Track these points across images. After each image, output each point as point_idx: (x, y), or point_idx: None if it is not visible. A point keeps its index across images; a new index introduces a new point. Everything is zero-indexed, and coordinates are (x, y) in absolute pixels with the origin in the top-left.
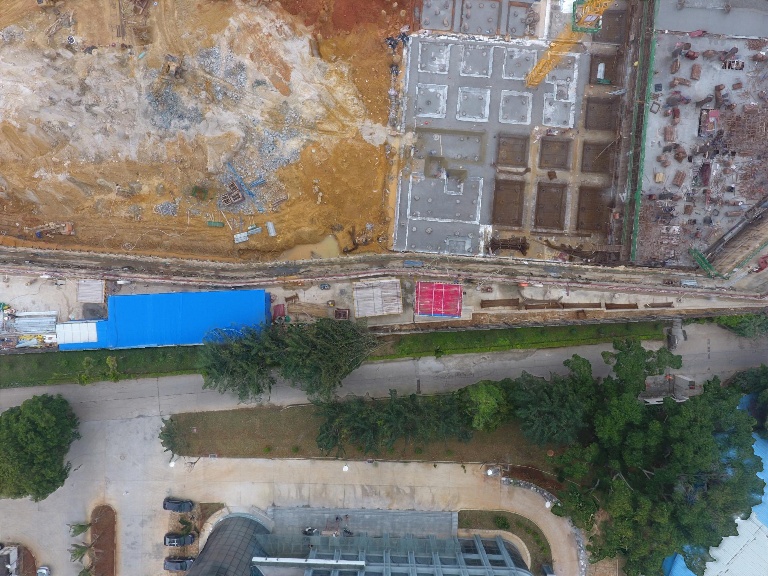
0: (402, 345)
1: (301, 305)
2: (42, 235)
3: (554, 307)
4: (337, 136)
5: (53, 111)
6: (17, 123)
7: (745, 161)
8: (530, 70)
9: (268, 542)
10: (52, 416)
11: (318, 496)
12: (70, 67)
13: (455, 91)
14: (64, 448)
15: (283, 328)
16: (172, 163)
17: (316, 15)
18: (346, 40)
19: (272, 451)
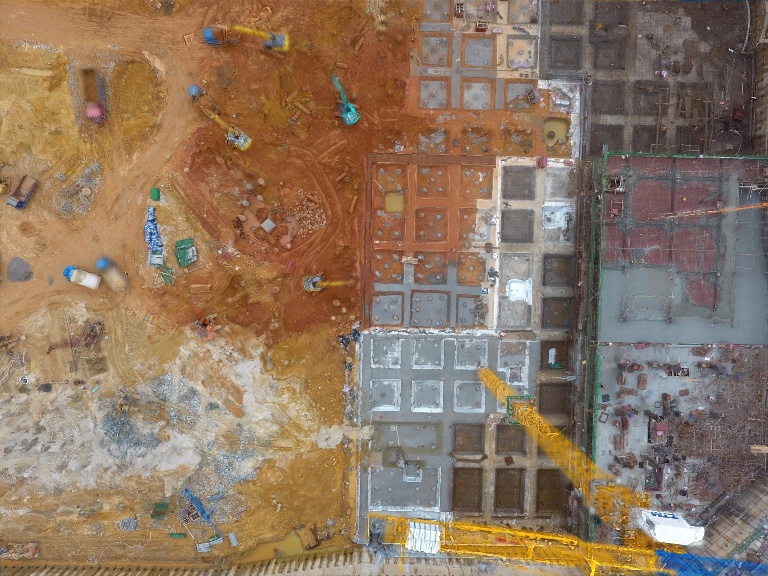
0: None
1: None
2: None
3: None
4: (292, 452)
5: (9, 457)
6: None
7: (696, 464)
8: (482, 358)
9: None
10: None
11: None
12: (25, 407)
13: (408, 385)
14: None
15: None
16: None
17: (267, 323)
18: (298, 341)
19: None
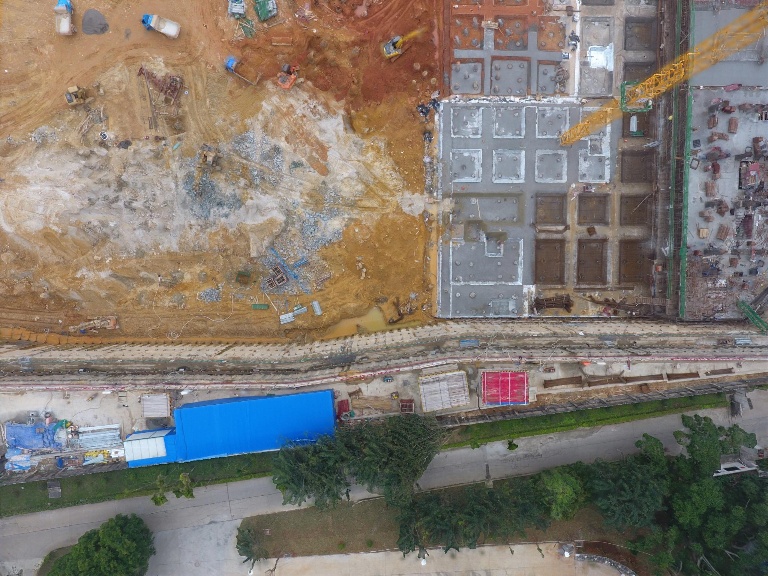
0: (474, 439)
1: (365, 399)
2: (86, 330)
3: (617, 382)
4: (378, 212)
5: (92, 211)
6: (58, 228)
7: None
8: (563, 127)
9: None
10: (133, 542)
11: None
12: (105, 163)
13: (490, 154)
14: (143, 568)
15: (349, 424)
16: (214, 251)
17: (346, 89)
18: (377, 111)
19: (346, 546)
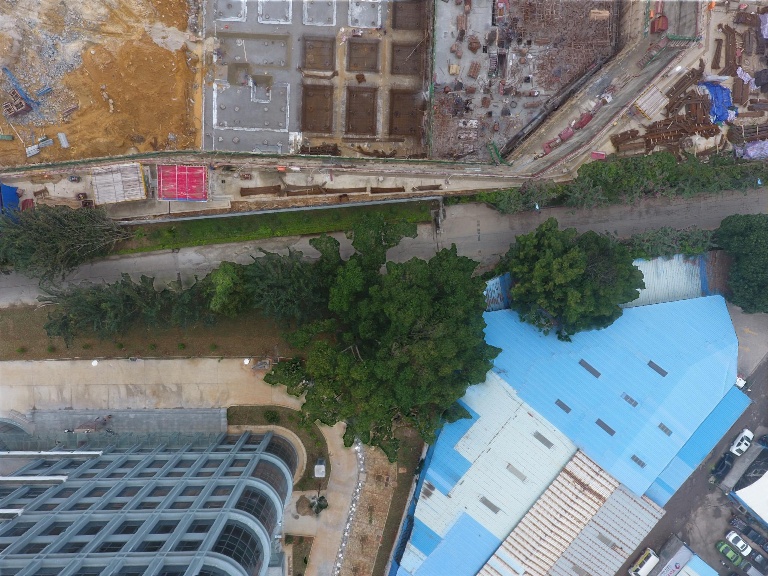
0: None
1: (51, 199)
2: None
3: (317, 193)
4: (122, 38)
5: None
6: None
7: (542, 50)
8: None
9: (12, 440)
10: None
11: (81, 397)
12: None
13: None
14: None
15: None
16: None
17: None
18: None
19: (28, 352)
